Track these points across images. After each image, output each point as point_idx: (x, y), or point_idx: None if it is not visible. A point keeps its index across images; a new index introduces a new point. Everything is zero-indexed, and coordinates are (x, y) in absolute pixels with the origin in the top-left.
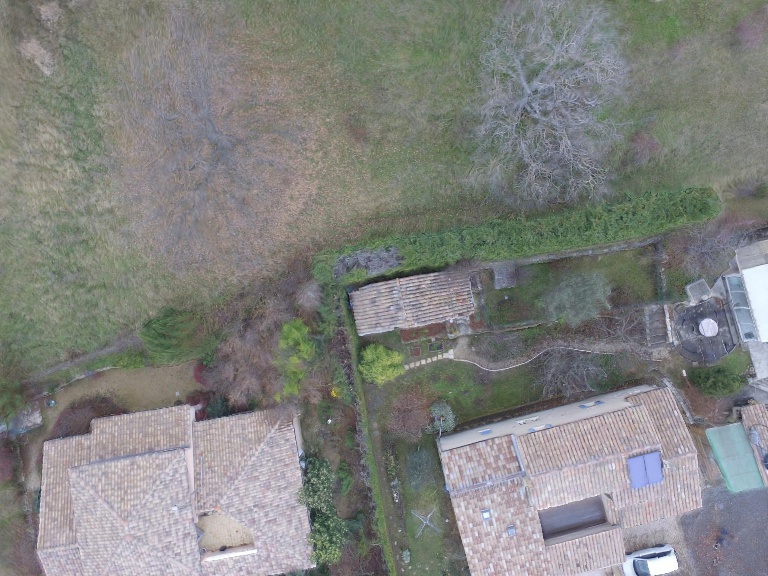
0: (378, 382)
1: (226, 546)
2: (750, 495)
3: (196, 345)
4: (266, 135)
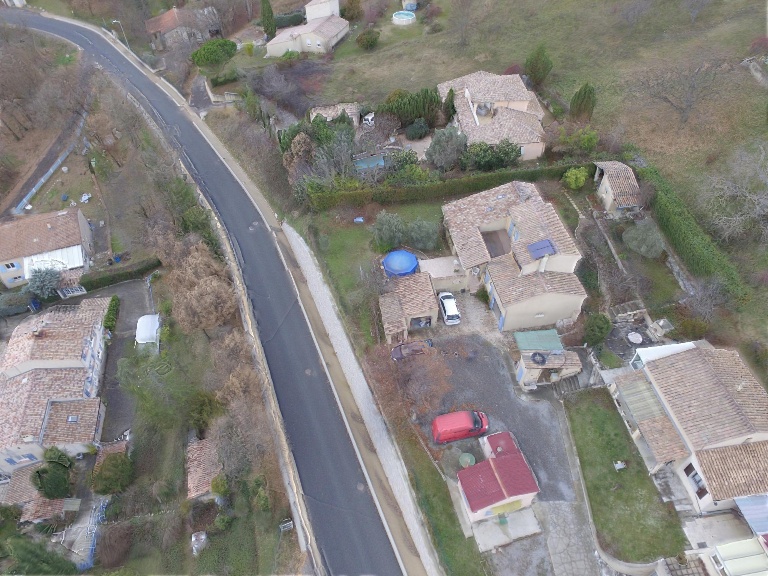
0: None
1: None
2: (497, 380)
3: None
4: (694, 133)
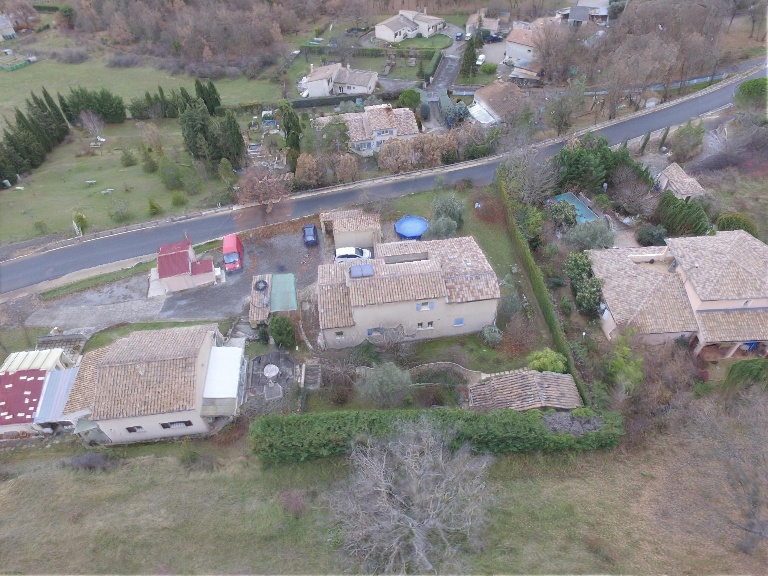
0: None
1: (650, 263)
2: None
3: (715, 390)
4: None
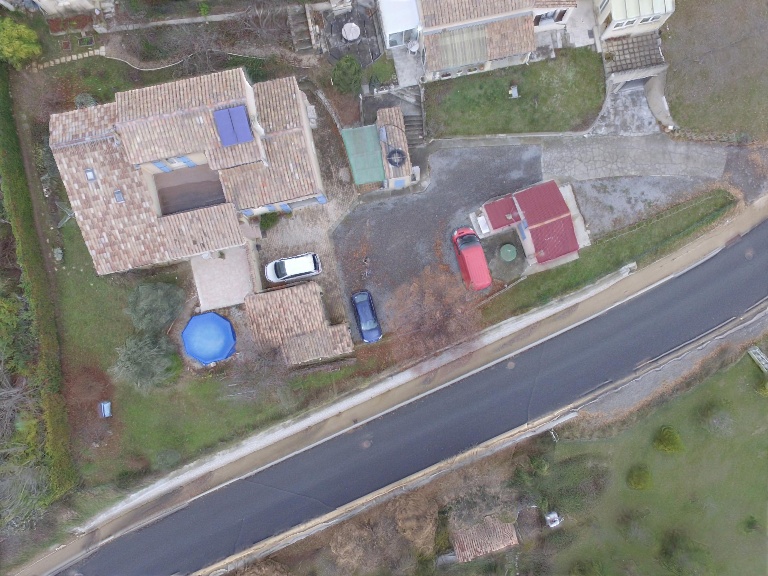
0: (5, 55)
1: None
2: (401, 213)
3: None
4: None
